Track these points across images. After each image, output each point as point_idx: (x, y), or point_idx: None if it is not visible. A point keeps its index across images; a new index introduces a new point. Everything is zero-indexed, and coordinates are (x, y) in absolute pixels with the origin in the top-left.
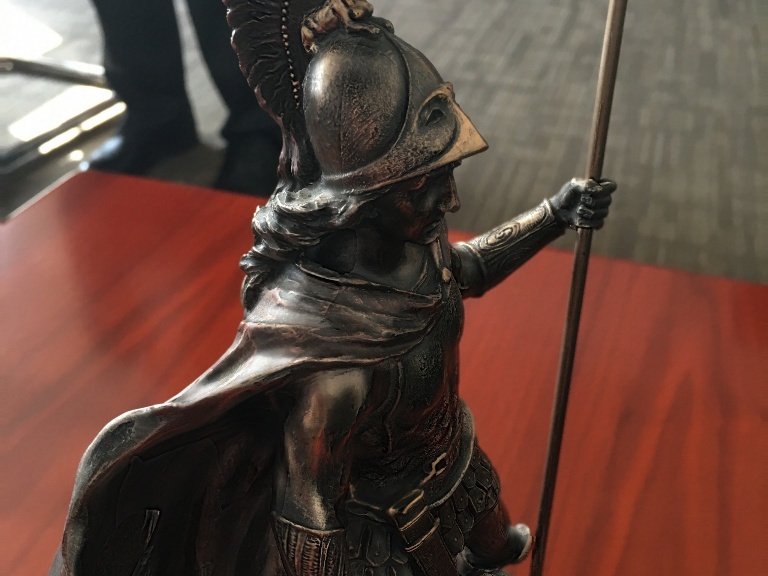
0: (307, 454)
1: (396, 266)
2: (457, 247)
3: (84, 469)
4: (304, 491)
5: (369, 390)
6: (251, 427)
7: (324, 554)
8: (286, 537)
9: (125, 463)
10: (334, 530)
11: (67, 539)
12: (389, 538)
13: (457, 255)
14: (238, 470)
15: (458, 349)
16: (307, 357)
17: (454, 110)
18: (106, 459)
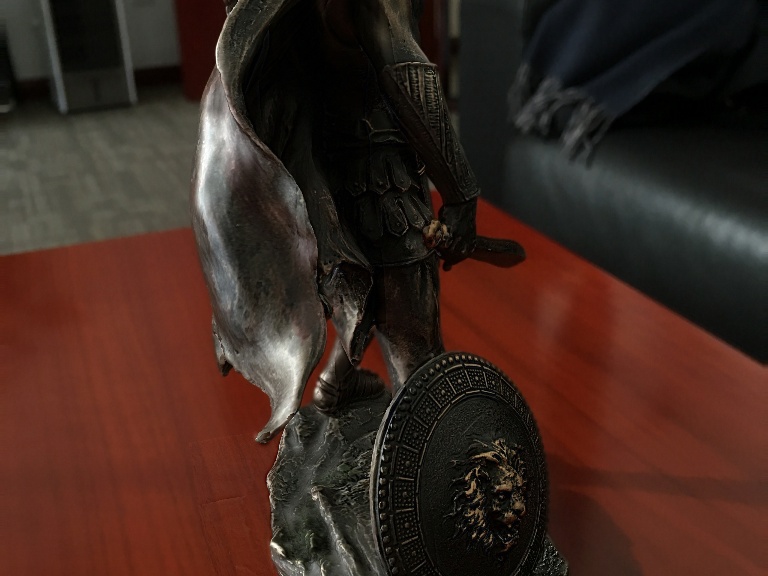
0: (399, 3)
1: None
2: None
3: (229, 51)
4: (405, 37)
5: None
6: (280, 77)
7: (439, 85)
8: (407, 78)
9: (261, 40)
10: None
11: (241, 117)
12: (404, 166)
13: None
14: (275, 130)
15: None
16: None
17: None
18: (248, 34)
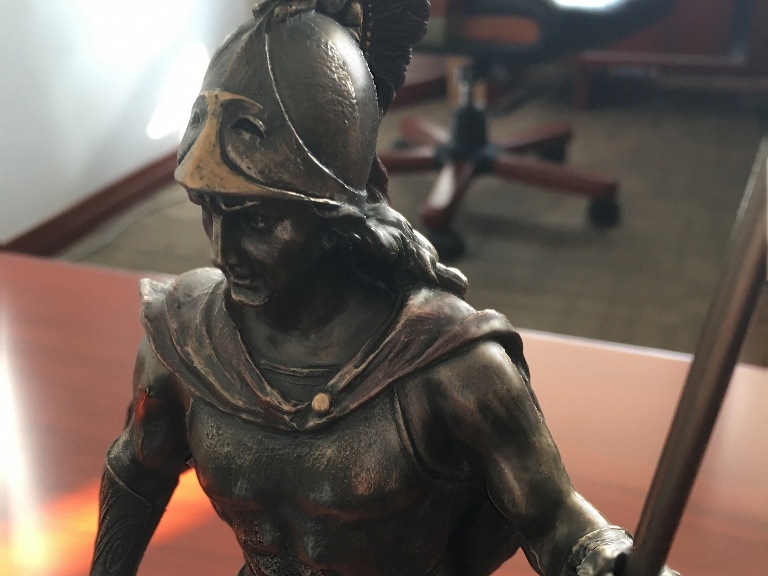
0: None
1: (288, 333)
2: (595, 521)
3: None
4: None
5: (159, 384)
6: None
7: None
8: None
9: None
10: (109, 466)
11: None
12: None
13: (517, 492)
14: None
15: (330, 524)
16: (147, 299)
17: (205, 124)
18: None
